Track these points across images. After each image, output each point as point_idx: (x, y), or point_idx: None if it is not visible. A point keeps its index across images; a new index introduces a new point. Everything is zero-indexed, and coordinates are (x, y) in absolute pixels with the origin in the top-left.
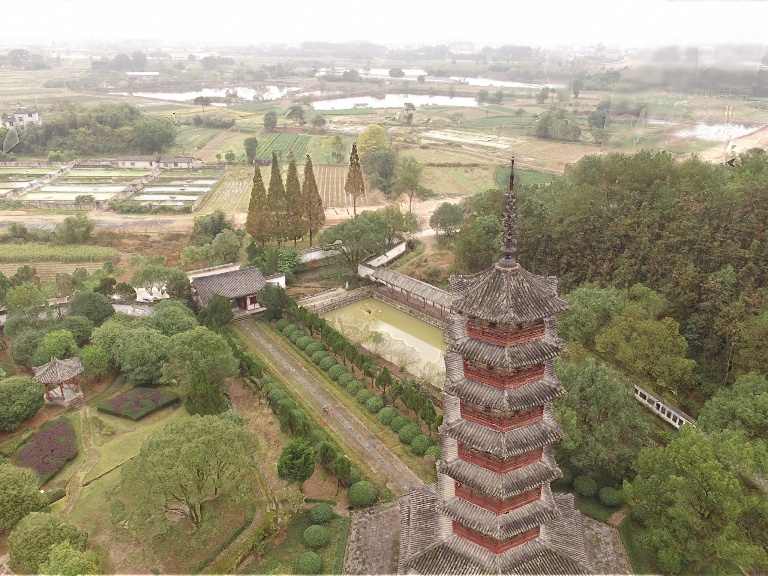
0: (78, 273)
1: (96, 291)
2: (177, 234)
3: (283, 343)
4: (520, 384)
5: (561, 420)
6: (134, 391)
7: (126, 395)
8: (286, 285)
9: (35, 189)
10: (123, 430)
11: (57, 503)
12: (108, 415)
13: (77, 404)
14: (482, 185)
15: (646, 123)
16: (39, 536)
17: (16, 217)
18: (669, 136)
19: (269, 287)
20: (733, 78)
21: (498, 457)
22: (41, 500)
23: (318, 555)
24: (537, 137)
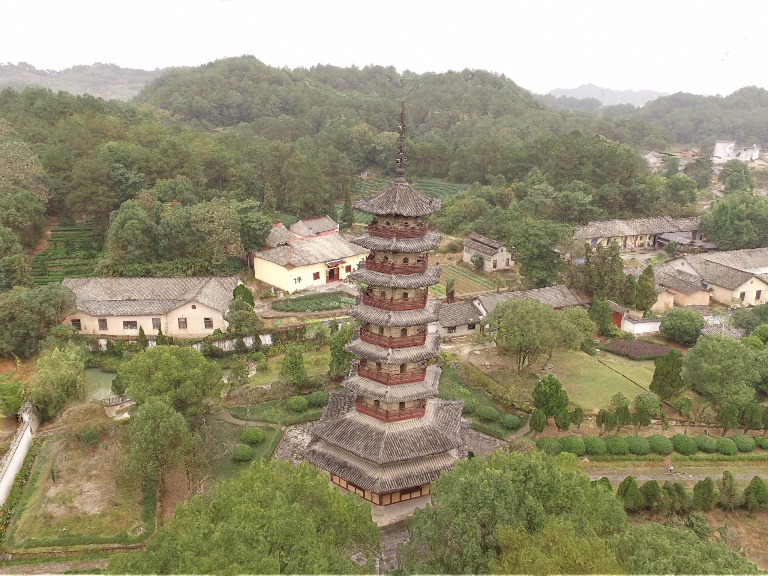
0: None
1: None
2: None
3: None
4: None
5: None
6: None
7: None
8: None
9: None
10: None
11: (584, 353)
12: None
13: None
14: None
15: None
16: None
17: None
18: None
19: None
20: None
21: None
22: None
23: None
24: None
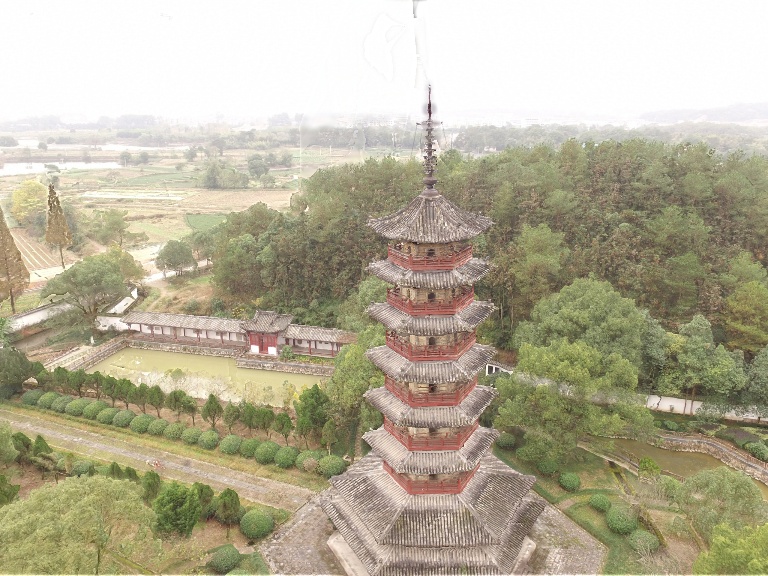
0: None
1: None
2: None
3: (45, 417)
4: (463, 308)
5: None
6: None
7: None
8: None
9: None
10: None
11: None
12: None
13: None
14: (179, 232)
15: (332, 152)
16: None
17: None
18: None
19: (3, 354)
20: (393, 109)
21: (462, 383)
22: None
23: None
24: (207, 188)
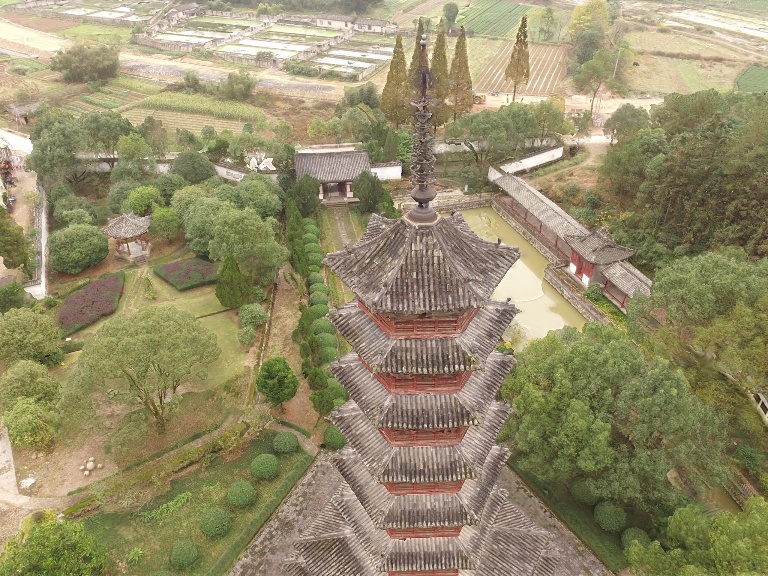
0: (205, 131)
1: (211, 152)
2: (328, 103)
3: None
4: (416, 392)
5: (586, 429)
6: (191, 261)
7: (182, 263)
8: (403, 176)
9: (234, 41)
10: (165, 297)
11: (74, 354)
12: (160, 279)
13: (140, 262)
14: (714, 87)
15: None
16: (13, 385)
17: (202, 67)
18: None
19: (363, 176)
20: None
21: None
22: (45, 349)
23: (258, 487)
24: None
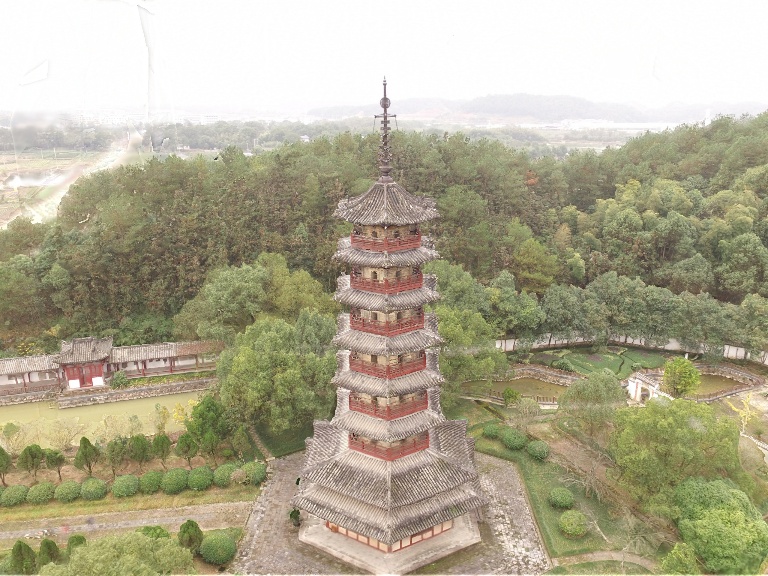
0: None
1: None
2: None
3: None
4: None
5: None
6: None
7: None
8: None
9: None
10: None
11: None
12: None
13: None
14: None
15: (57, 155)
16: None
17: None
18: (85, 165)
19: None
20: (126, 106)
21: None
22: None
23: None
24: None
